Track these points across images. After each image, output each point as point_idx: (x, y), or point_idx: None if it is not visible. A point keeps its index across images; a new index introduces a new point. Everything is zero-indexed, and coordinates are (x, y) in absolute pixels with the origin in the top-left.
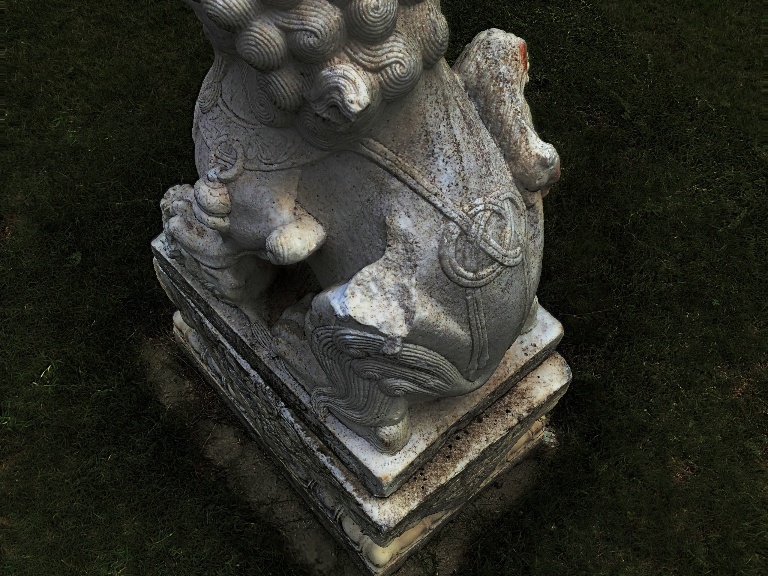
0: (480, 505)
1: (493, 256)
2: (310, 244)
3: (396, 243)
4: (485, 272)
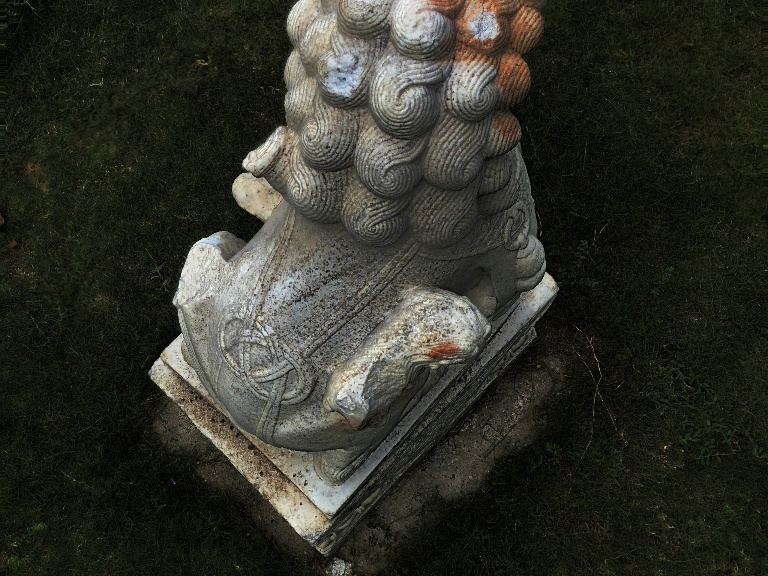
0: (265, 501)
1: (240, 362)
2: (249, 207)
3: (234, 268)
4: (230, 359)
